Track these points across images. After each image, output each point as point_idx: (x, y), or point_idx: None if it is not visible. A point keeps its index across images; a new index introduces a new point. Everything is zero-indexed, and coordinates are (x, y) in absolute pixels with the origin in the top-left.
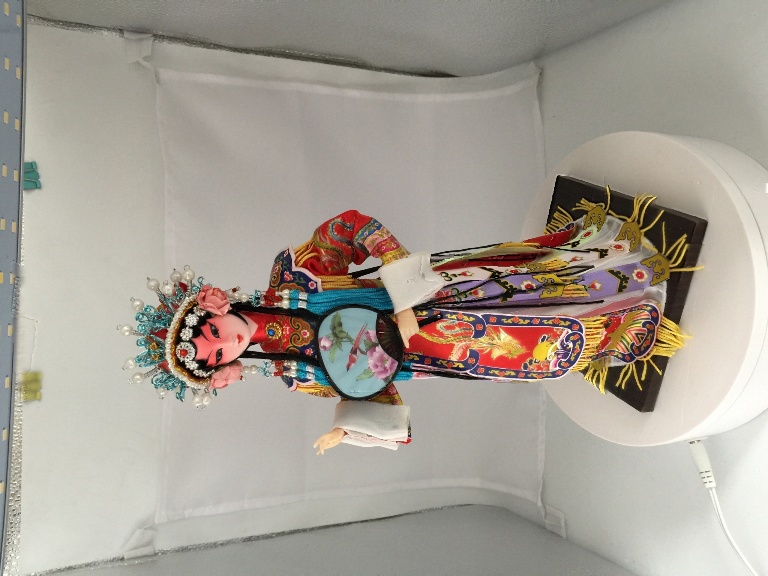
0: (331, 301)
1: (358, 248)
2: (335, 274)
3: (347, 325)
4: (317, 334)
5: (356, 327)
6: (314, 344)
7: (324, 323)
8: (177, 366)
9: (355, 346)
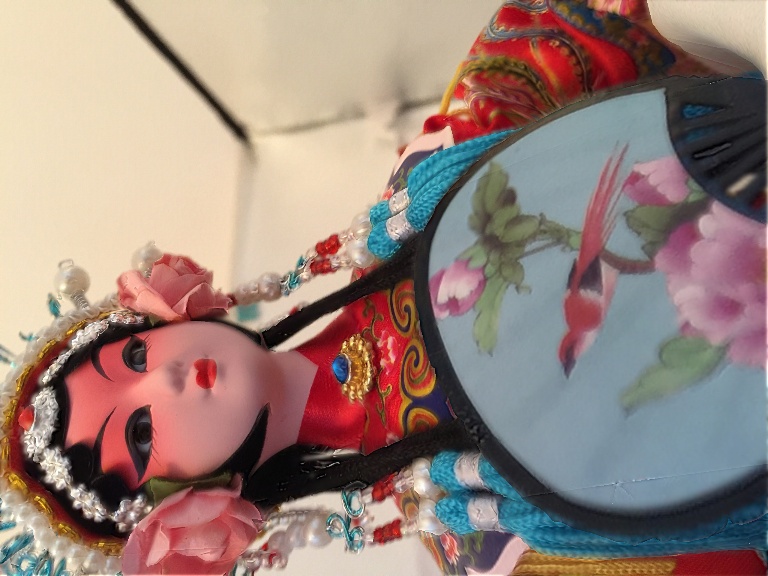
0: (477, 155)
1: (580, 31)
2: None
3: (536, 188)
4: (424, 267)
5: (576, 179)
6: None
7: (447, 219)
8: (17, 471)
9: (586, 252)
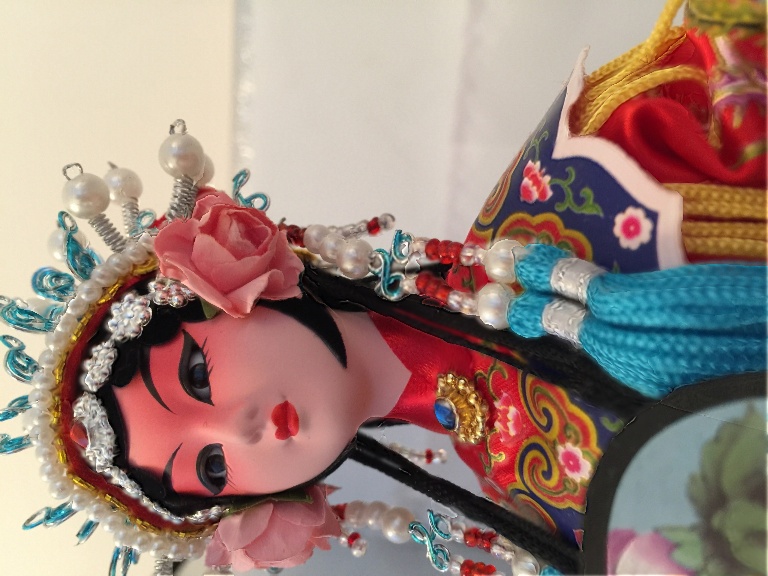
0: (723, 329)
1: None
2: None
3: None
4: (605, 503)
5: None
6: (586, 547)
7: (654, 453)
8: (79, 470)
9: None
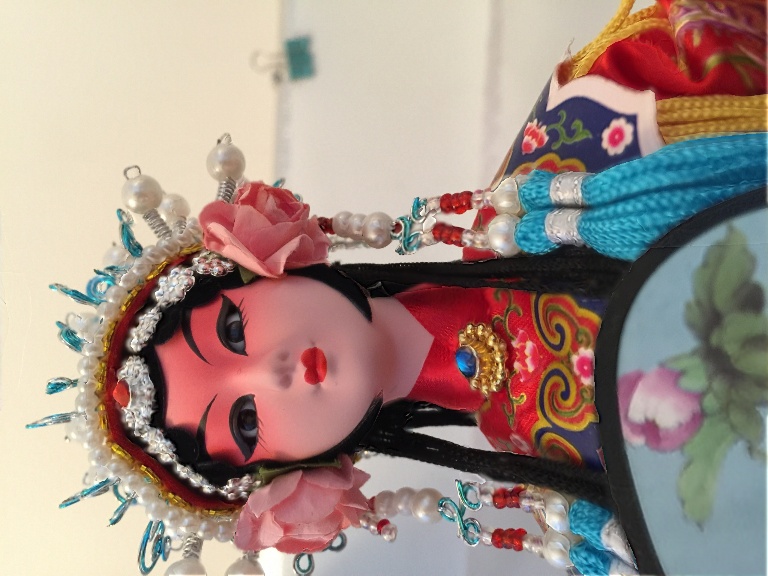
0: (700, 180)
1: None
2: (749, 91)
3: None
4: (611, 353)
5: None
6: (600, 409)
7: (651, 293)
8: (118, 439)
9: None
